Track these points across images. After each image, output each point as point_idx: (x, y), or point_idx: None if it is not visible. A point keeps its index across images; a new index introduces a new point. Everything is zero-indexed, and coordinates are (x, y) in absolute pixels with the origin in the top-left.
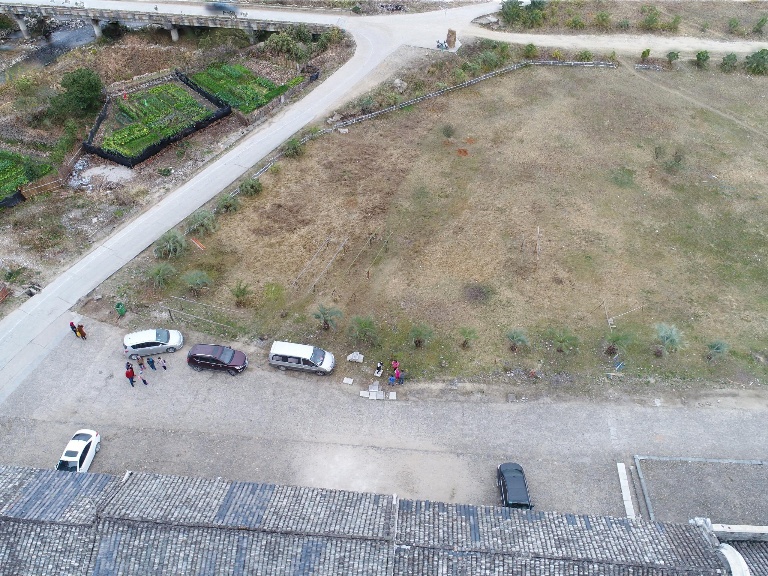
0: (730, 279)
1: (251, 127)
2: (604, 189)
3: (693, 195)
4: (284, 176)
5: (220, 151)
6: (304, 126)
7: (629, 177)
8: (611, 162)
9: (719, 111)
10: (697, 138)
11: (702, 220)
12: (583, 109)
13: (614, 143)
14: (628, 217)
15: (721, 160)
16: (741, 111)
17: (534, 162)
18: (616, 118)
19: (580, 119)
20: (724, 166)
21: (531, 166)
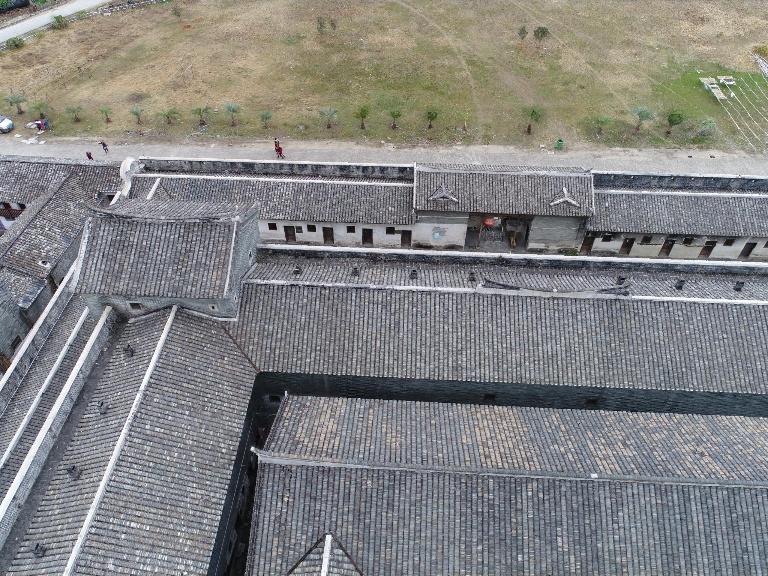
0: (319, 91)
1: (38, 12)
2: (274, 46)
3: (336, 49)
4: (45, 39)
5: (6, 25)
6: (79, 11)
7: (299, 40)
8: (293, 32)
9: (405, 4)
10: (371, 19)
11: (330, 62)
12: (300, 2)
13: (305, 21)
14: (278, 60)
15: (377, 31)
16: (421, 3)
17: (236, 32)
18: (320, 7)
19: (292, 8)
20: (375, 34)
21: (232, 34)
